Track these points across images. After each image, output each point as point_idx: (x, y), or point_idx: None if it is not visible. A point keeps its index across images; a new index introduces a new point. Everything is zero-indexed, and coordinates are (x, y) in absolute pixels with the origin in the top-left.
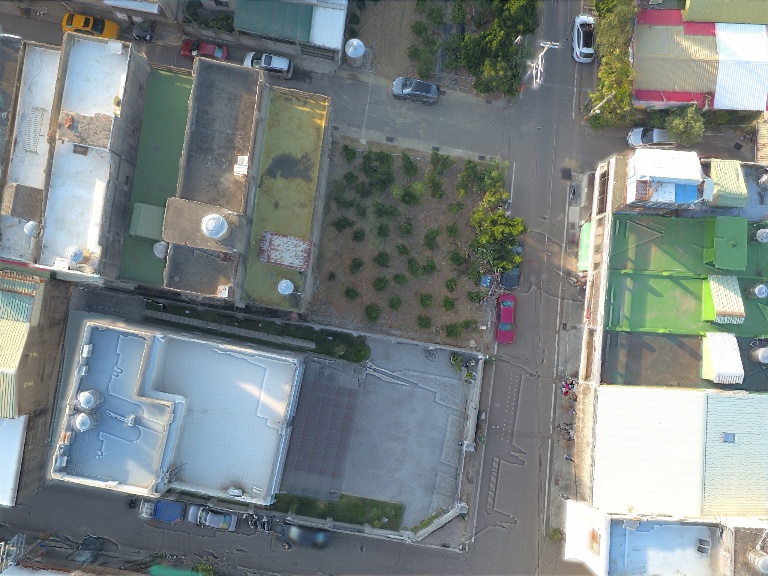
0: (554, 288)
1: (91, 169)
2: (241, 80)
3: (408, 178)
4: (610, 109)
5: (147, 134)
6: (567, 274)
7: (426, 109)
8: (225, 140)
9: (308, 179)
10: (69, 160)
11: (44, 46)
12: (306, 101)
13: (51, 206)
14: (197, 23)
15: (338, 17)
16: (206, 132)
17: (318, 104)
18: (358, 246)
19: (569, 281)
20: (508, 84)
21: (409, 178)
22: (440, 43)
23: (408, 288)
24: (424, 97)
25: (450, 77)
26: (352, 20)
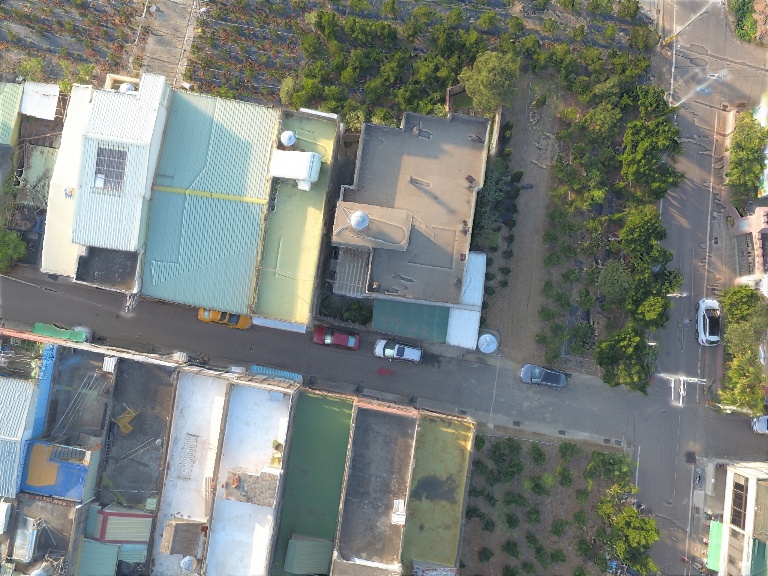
0: (679, 574)
1: (250, 513)
2: (396, 423)
3: (535, 463)
4: (742, 412)
5: (296, 457)
6: (692, 559)
7: (552, 392)
8: (381, 484)
9: (453, 501)
10: (229, 504)
11: (198, 374)
12: (451, 422)
13: (212, 551)
14: (333, 318)
15: (474, 318)
16: (363, 476)
17: (462, 425)
18: (486, 532)
19: (694, 566)
20: (641, 385)
21: (536, 463)
22: (566, 325)
23: (535, 574)
24: (553, 386)
25: (576, 359)
26: (482, 308)
